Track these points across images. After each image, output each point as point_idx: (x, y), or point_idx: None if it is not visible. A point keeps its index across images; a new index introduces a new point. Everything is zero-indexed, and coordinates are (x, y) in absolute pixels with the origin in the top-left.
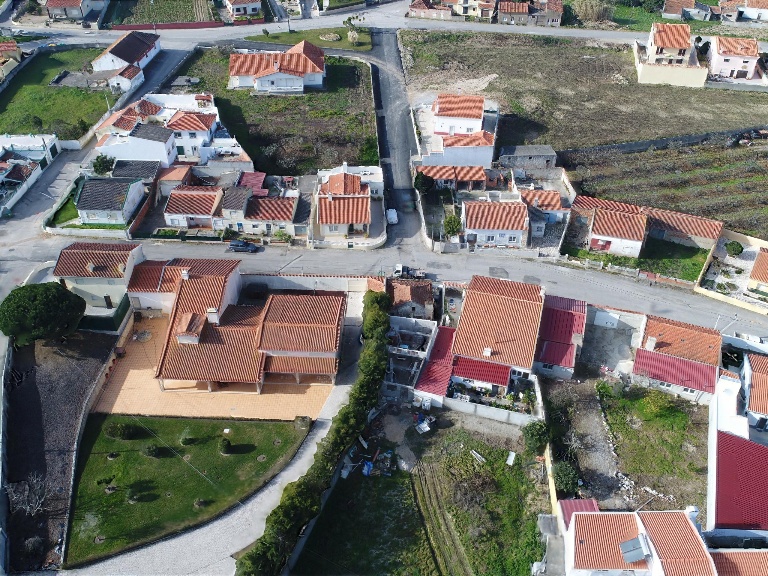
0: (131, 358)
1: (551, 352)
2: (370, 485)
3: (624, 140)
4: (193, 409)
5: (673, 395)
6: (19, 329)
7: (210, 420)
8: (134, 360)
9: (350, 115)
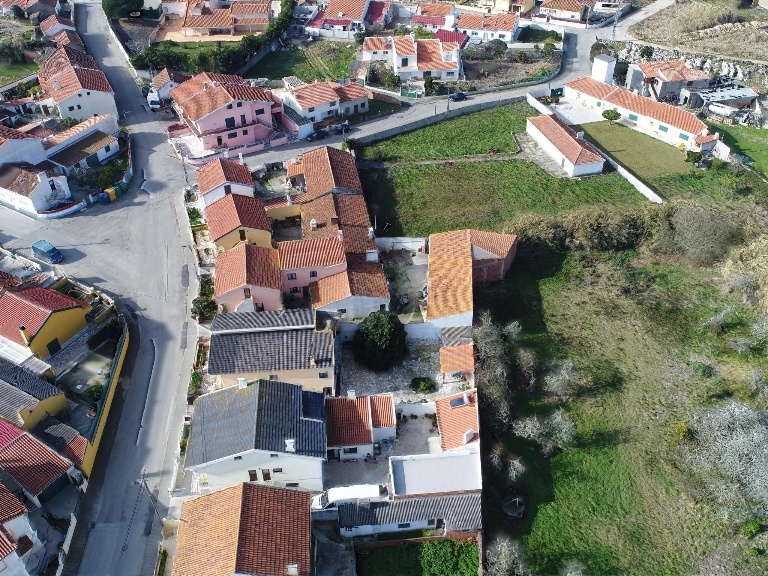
0: (167, 30)
1: (372, 17)
2: None
3: None
4: (201, 40)
5: (429, 31)
6: (115, 5)
7: (210, 42)
8: (169, 30)
9: None
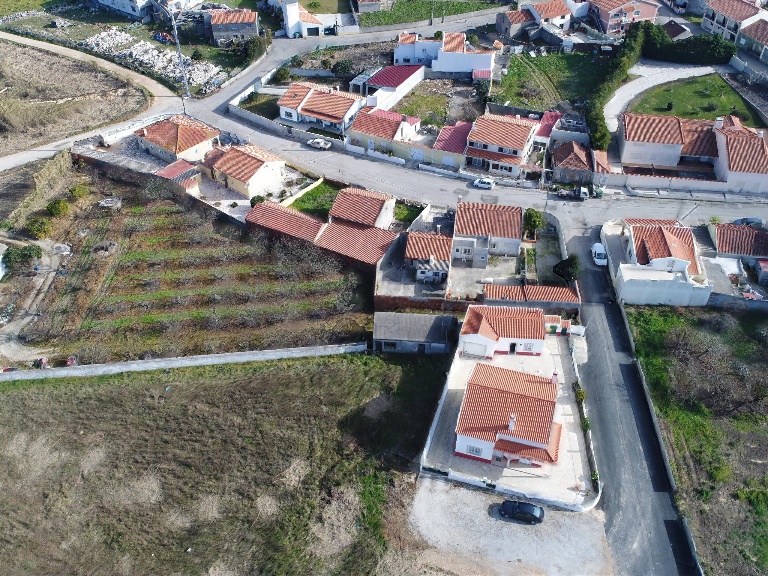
0: None
1: None
2: (585, 97)
3: (233, 379)
4: None
5: None
6: None
7: None
8: None
9: (728, 489)
